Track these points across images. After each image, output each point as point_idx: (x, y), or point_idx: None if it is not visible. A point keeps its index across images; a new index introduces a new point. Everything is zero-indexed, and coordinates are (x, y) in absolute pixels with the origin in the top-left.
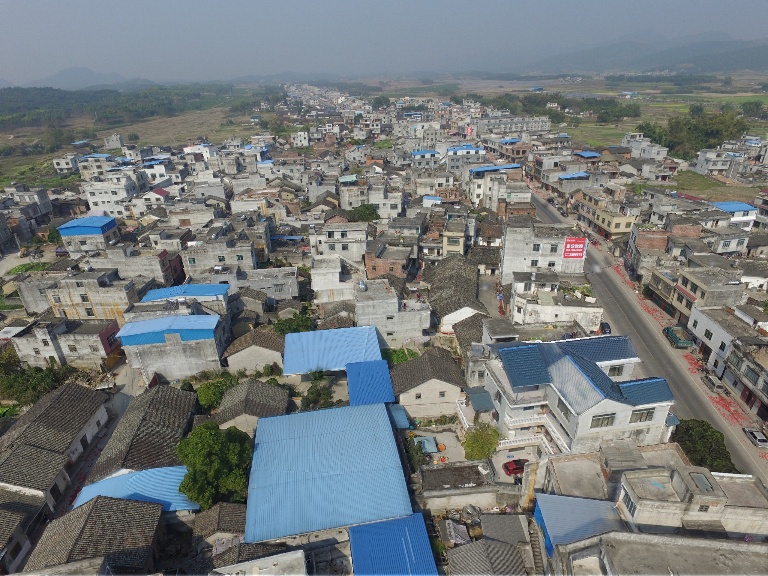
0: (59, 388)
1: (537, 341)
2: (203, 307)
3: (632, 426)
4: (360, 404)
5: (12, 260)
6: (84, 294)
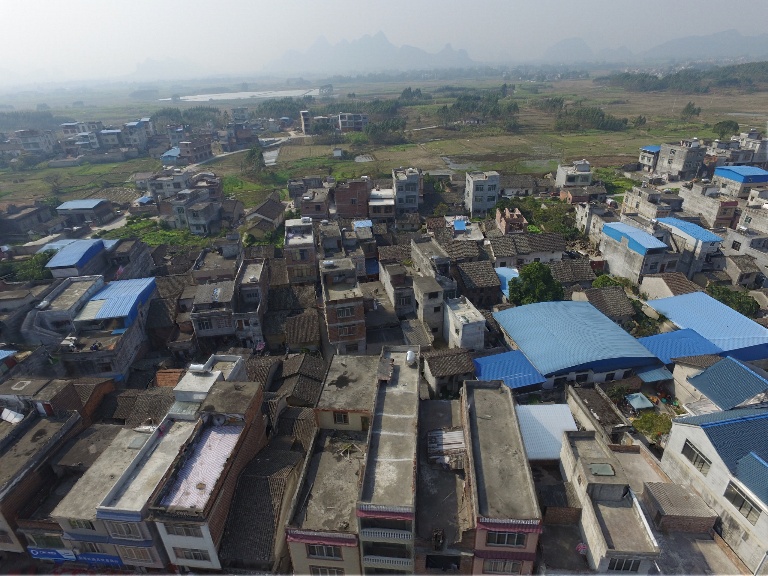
0: None
1: None
2: (671, 238)
3: (727, 504)
4: (643, 344)
5: (680, 184)
6: (639, 202)
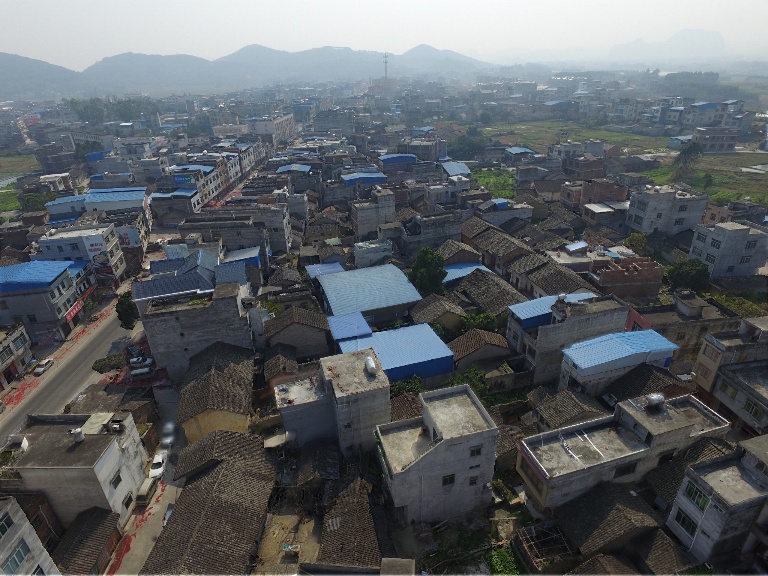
0: (590, 289)
1: (201, 292)
2: None
3: None
4: (352, 313)
5: None
6: None
